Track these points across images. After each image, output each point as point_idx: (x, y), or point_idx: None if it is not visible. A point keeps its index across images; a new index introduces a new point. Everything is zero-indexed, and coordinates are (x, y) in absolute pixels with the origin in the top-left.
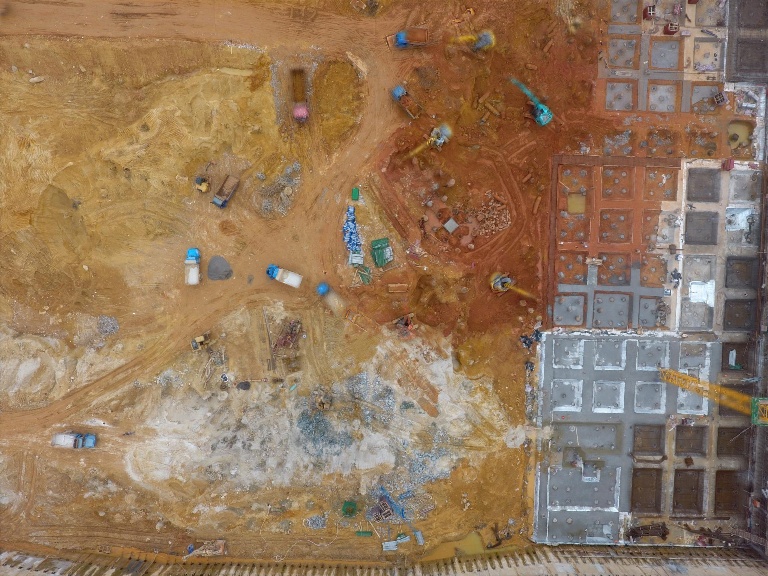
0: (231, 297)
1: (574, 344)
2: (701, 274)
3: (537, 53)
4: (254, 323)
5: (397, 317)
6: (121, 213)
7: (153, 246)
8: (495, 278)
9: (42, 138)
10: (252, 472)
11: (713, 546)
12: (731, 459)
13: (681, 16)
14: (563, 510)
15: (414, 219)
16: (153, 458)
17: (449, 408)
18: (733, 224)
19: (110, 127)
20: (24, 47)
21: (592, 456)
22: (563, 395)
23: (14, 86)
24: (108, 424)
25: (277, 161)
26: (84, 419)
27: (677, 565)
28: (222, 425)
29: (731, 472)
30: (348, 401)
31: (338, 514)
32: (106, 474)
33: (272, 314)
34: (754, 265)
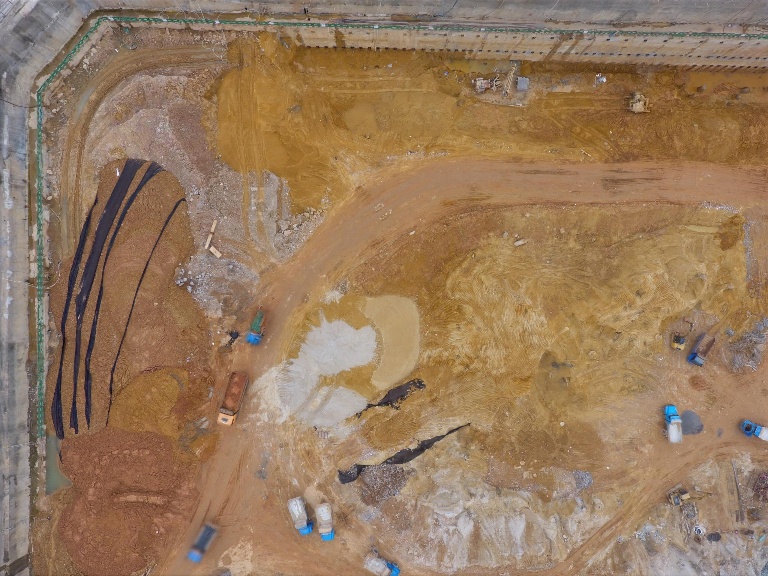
0: (701, 450)
1: None
2: None
3: None
4: (723, 475)
5: None
6: (607, 374)
7: (625, 401)
8: None
9: (535, 303)
10: None
11: None
12: None
13: None
14: None
15: None
16: None
17: None
18: None
19: (584, 285)
20: (524, 216)
21: None
22: None
23: (502, 250)
24: None
25: (742, 316)
26: None
27: None
28: None
29: None
30: None
31: None
32: None
33: (740, 466)
34: None
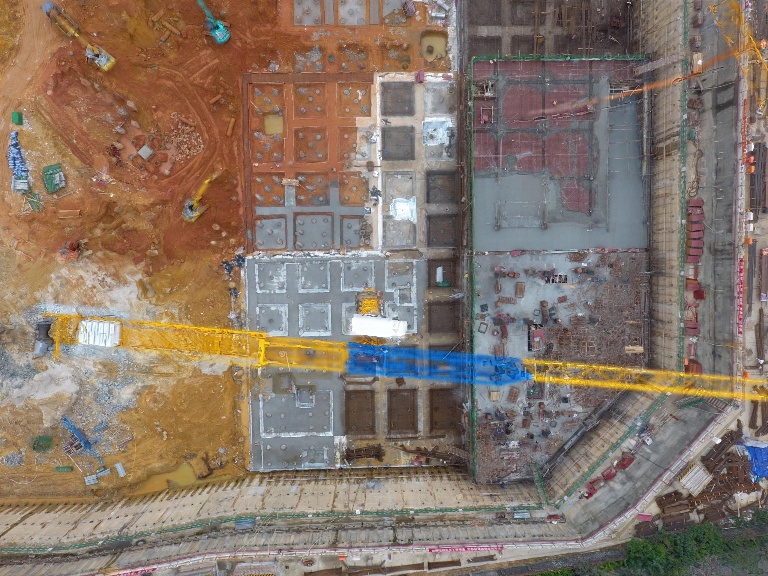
0: None
1: (278, 268)
2: (403, 191)
3: None
4: None
5: None
6: None
7: None
8: None
9: None
10: None
11: (429, 465)
12: (443, 377)
13: None
14: (277, 437)
15: (96, 145)
16: None
17: (132, 335)
18: (435, 139)
19: None
20: None
21: (302, 381)
22: (270, 320)
23: None
24: None
25: None
26: None
27: (377, 483)
28: None
29: (447, 390)
30: (28, 332)
31: (35, 450)
32: None
33: None
34: (456, 179)
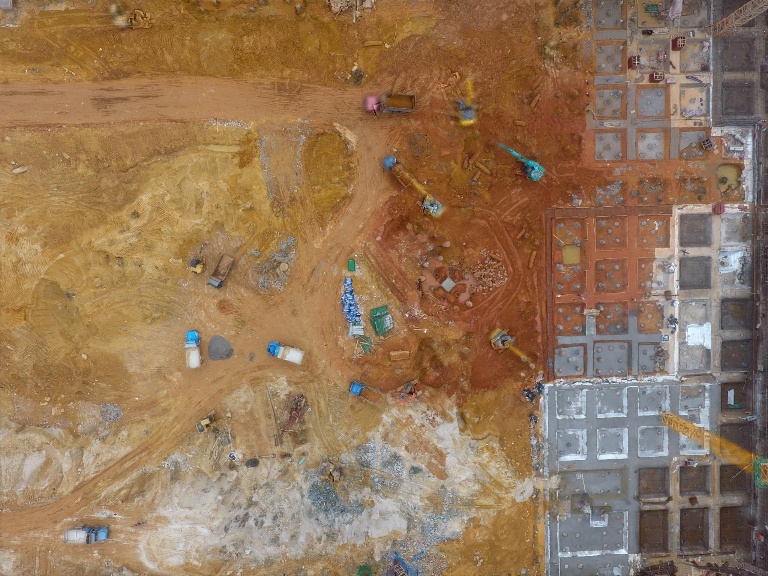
0: (234, 376)
1: (576, 394)
2: (697, 317)
3: (524, 108)
4: (258, 400)
5: (401, 384)
6: (117, 301)
7: (151, 330)
8: (495, 335)
9: (30, 231)
10: (266, 548)
11: None
12: (734, 495)
13: (665, 63)
14: (574, 556)
15: (411, 283)
16: (167, 545)
17: (457, 470)
18: (726, 266)
19: (99, 212)
20: (5, 140)
21: (599, 502)
22: (568, 444)
23: None
24: (119, 515)
25: (271, 236)
26: (95, 511)
27: None
28: (233, 505)
29: (735, 507)
30: (357, 470)
31: None
32: (121, 564)
33: (276, 390)
34: (748, 305)
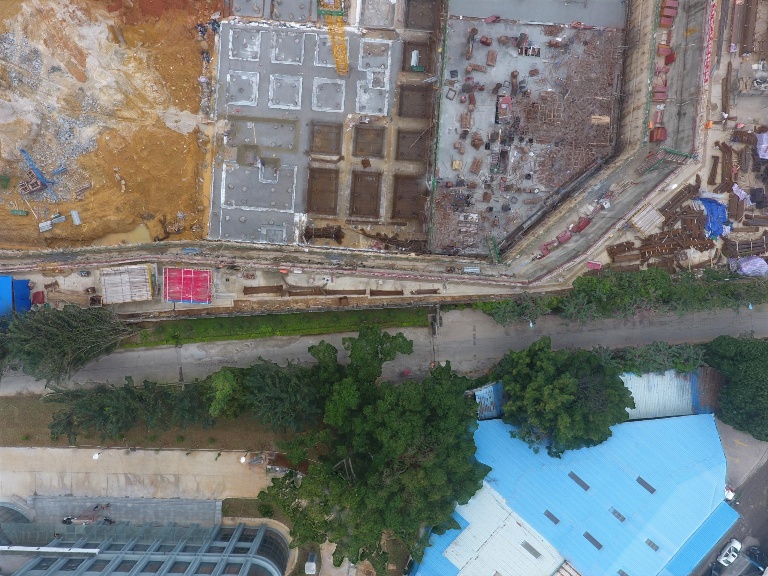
0: None
1: (253, 36)
2: None
3: None
4: None
5: None
6: None
7: None
8: None
9: None
10: None
11: (387, 251)
12: (410, 163)
13: None
14: (237, 208)
15: None
16: None
17: (98, 74)
18: None
19: None
20: None
21: (267, 153)
22: (240, 89)
23: None
24: None
25: None
26: None
27: None
28: None
29: (412, 179)
30: None
31: None
32: None
33: None
34: None
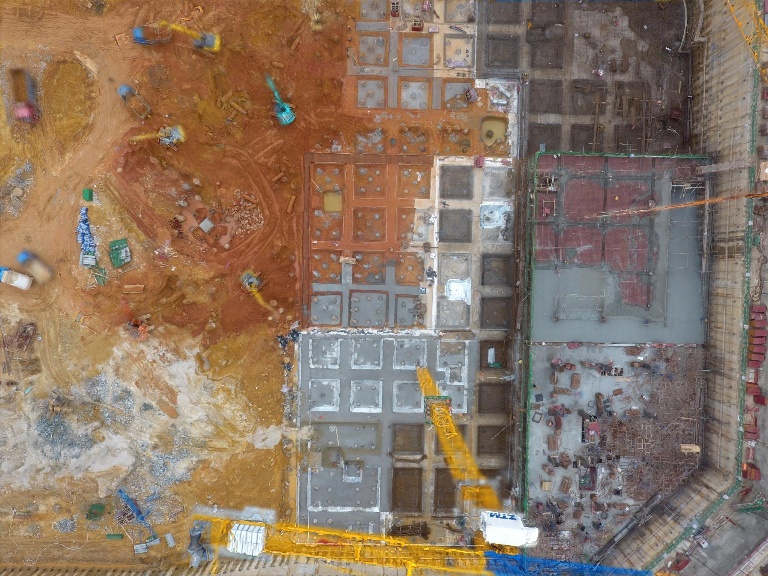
0: None
1: (332, 344)
2: (458, 272)
3: (285, 51)
4: None
5: None
6: None
7: None
8: (247, 278)
9: None
10: None
11: (474, 545)
12: (491, 458)
13: (431, 12)
14: (324, 511)
15: (160, 219)
16: None
17: (189, 409)
18: (492, 221)
19: None
20: None
21: (351, 456)
22: (322, 395)
23: None
24: None
25: (11, 162)
26: None
27: None
28: None
29: (494, 471)
30: (87, 403)
31: None
32: None
33: (6, 316)
34: (511, 262)
